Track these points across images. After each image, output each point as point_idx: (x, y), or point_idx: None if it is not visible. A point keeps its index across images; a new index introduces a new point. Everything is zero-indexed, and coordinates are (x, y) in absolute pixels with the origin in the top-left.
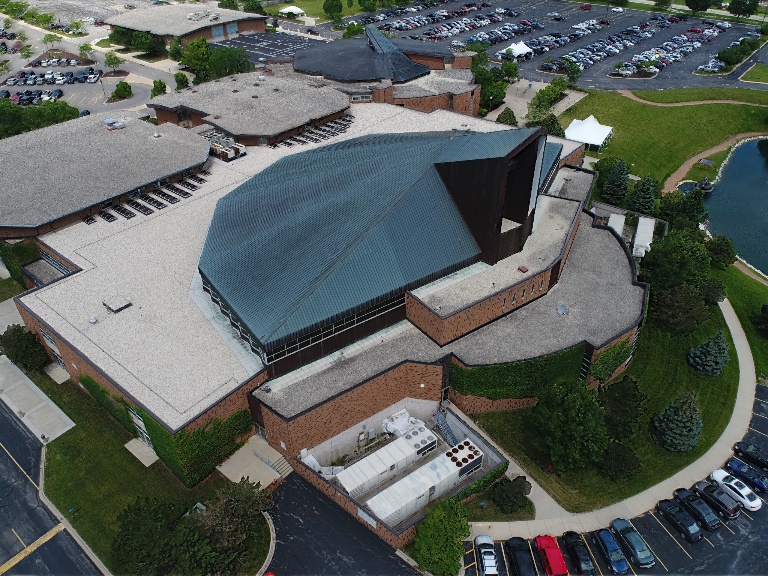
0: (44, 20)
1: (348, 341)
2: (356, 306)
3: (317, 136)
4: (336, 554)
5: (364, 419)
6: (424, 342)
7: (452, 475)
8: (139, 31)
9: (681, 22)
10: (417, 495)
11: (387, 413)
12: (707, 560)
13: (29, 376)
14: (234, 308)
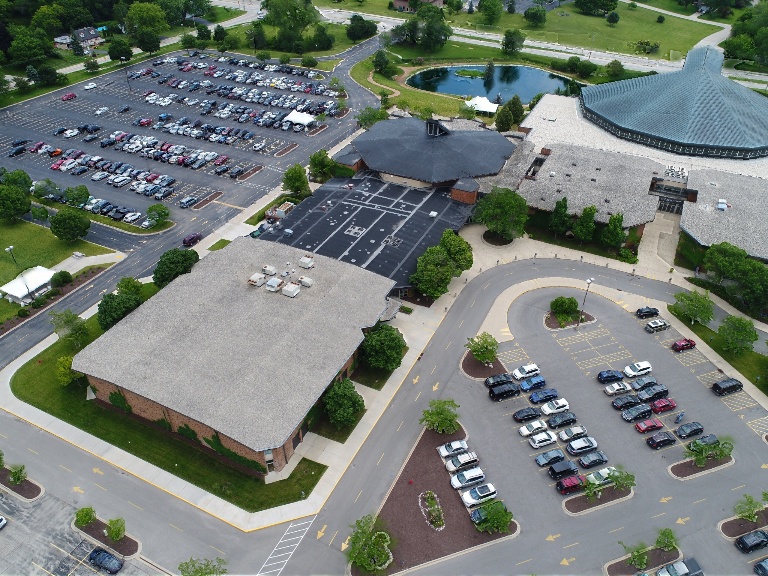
0: None
1: None
2: None
3: None
4: None
5: None
6: None
7: None
8: None
9: None
10: None
11: None
12: None
13: None
14: None
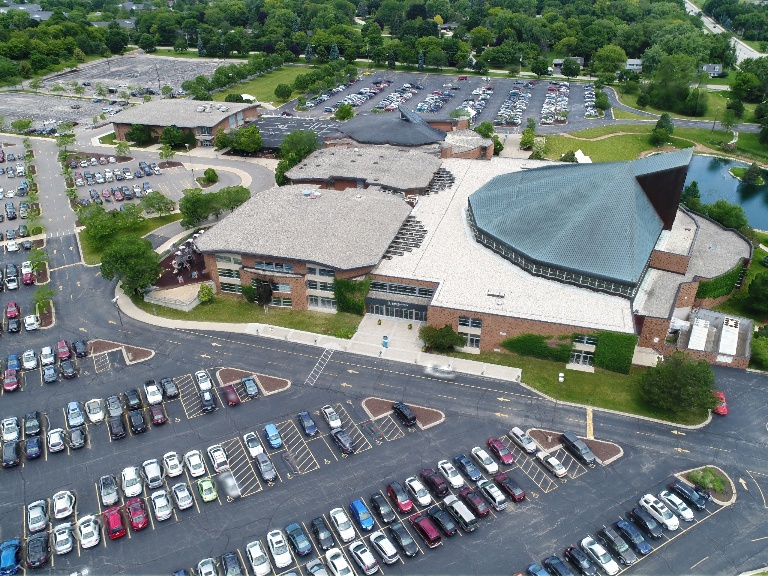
0: (24, 125)
1: None
2: None
3: (444, 184)
4: (724, 379)
5: None
6: (673, 275)
7: None
8: (160, 126)
9: (537, 84)
10: (736, 343)
11: None
12: None
13: (452, 356)
14: (594, 272)
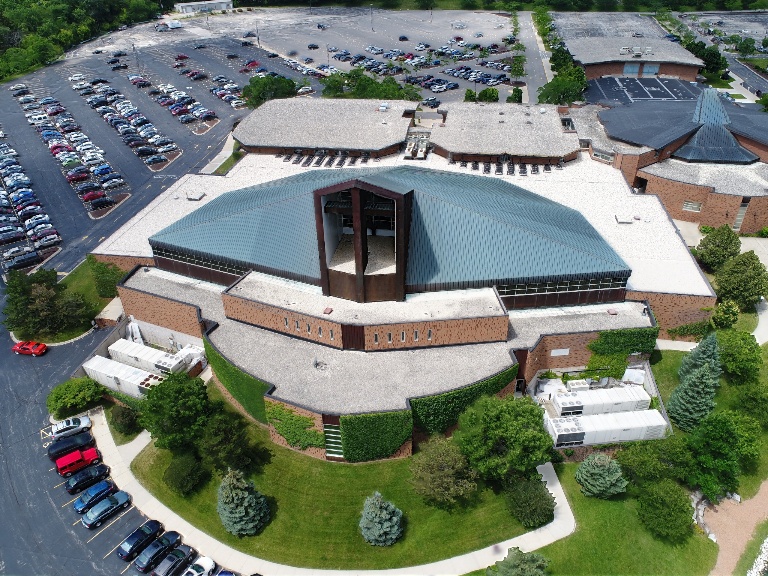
0: (542, 33)
1: (208, 278)
2: (209, 253)
3: (495, 169)
4: (68, 366)
5: (172, 329)
6: None
7: (132, 384)
8: None
9: None
10: (107, 373)
11: (190, 340)
12: (104, 570)
13: None
14: None
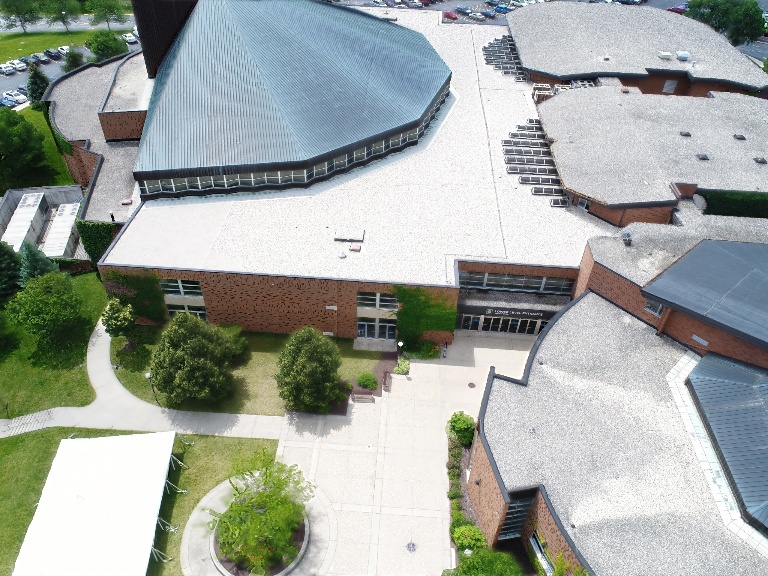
0: None
1: None
2: None
3: None
4: None
5: None
6: None
7: None
8: None
9: None
10: None
11: None
12: None
13: None
14: None
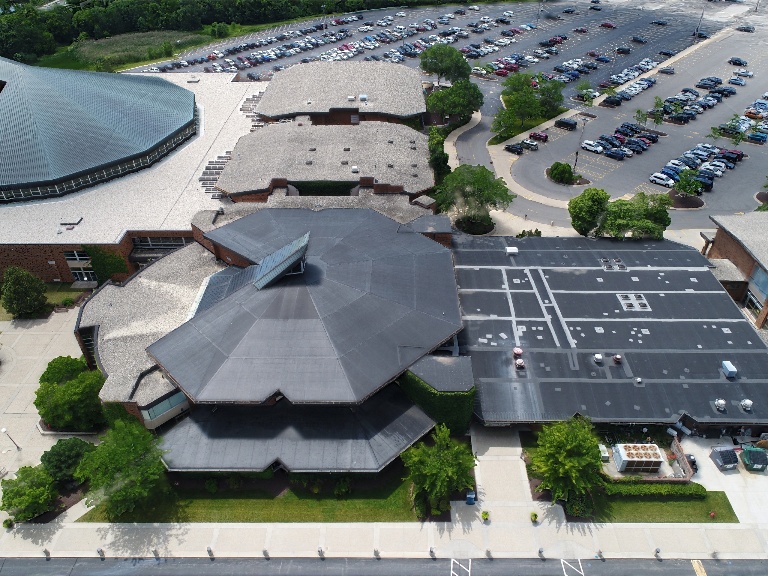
0: None
1: None
2: None
3: None
4: None
5: None
6: None
7: None
8: None
9: None
10: None
11: None
12: None
13: None
14: None
